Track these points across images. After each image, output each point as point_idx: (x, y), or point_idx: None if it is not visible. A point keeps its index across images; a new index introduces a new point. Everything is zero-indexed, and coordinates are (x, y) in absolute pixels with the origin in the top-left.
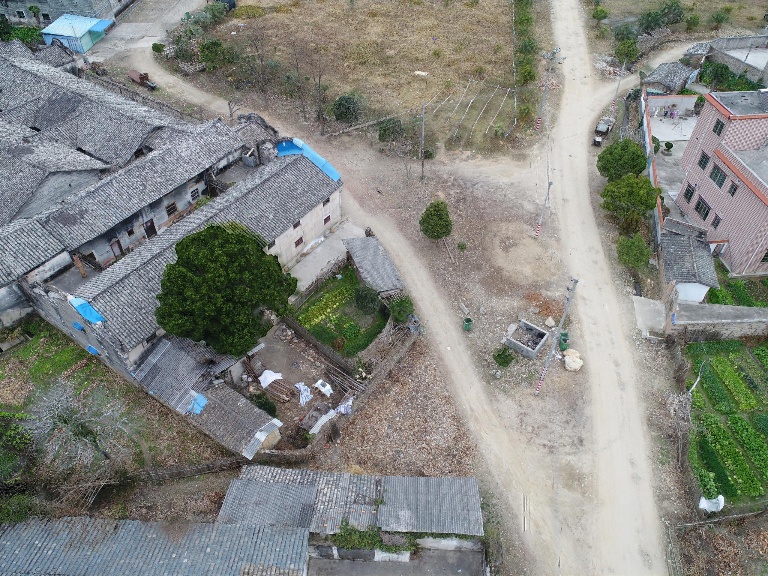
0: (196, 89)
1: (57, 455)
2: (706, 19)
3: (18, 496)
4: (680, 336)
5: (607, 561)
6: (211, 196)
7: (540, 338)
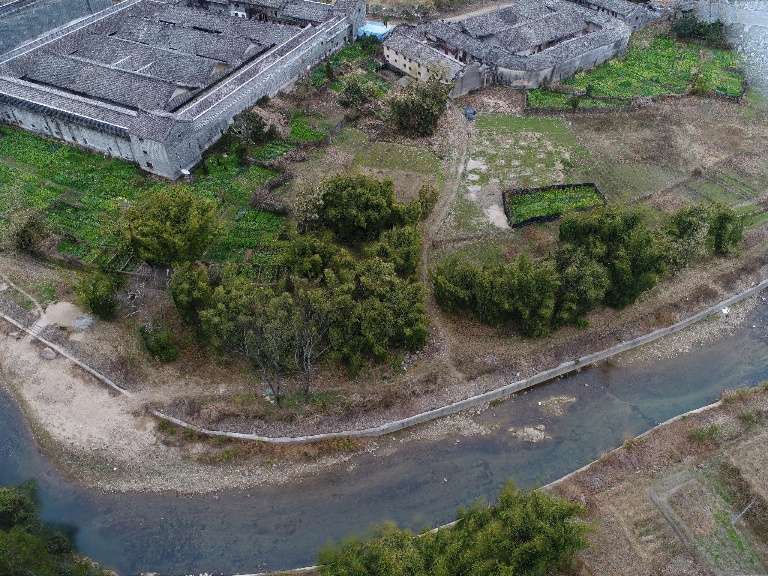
0: (454, 17)
1: None
2: None
3: None
4: None
5: None
6: None
7: None
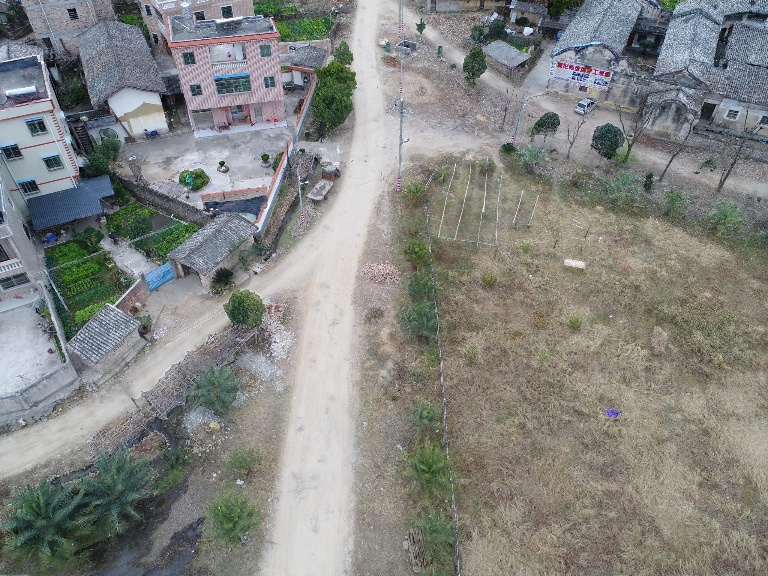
0: None
1: None
2: None
3: None
4: None
5: (378, 6)
6: None
7: None
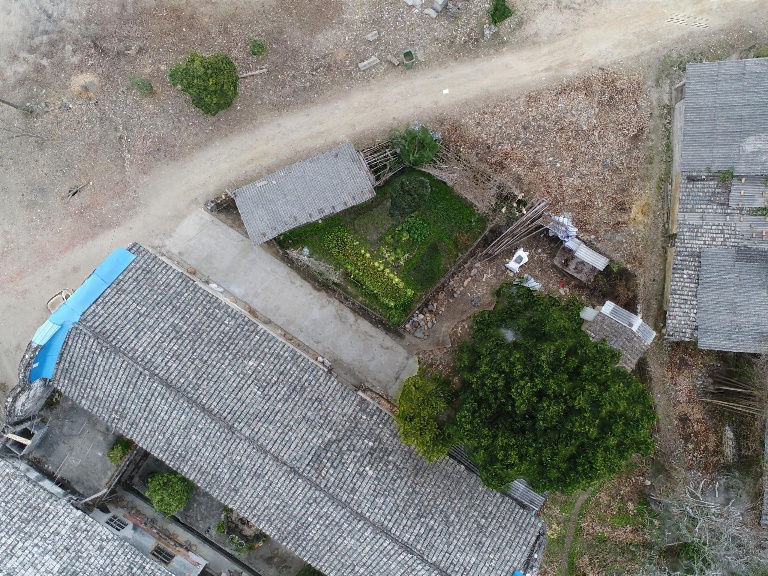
0: None
1: (621, 570)
2: None
3: None
4: None
5: None
6: None
7: None
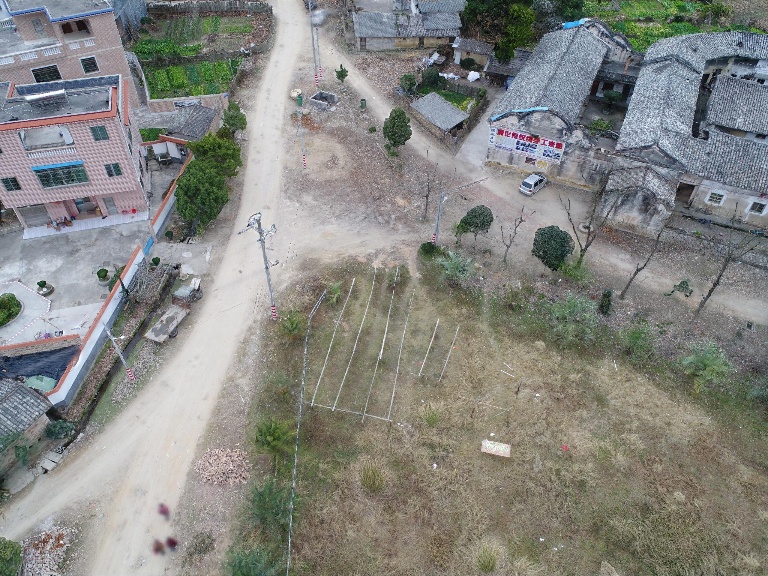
0: None
1: None
2: None
3: (539, 8)
4: None
5: None
6: None
7: None
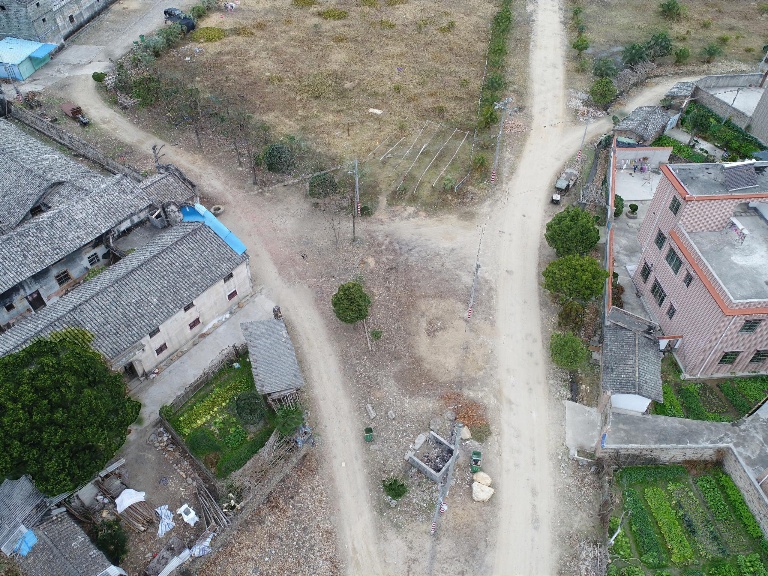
0: (131, 125)
1: None
2: (699, 50)
3: None
4: (612, 460)
5: None
6: (114, 260)
7: (450, 454)
